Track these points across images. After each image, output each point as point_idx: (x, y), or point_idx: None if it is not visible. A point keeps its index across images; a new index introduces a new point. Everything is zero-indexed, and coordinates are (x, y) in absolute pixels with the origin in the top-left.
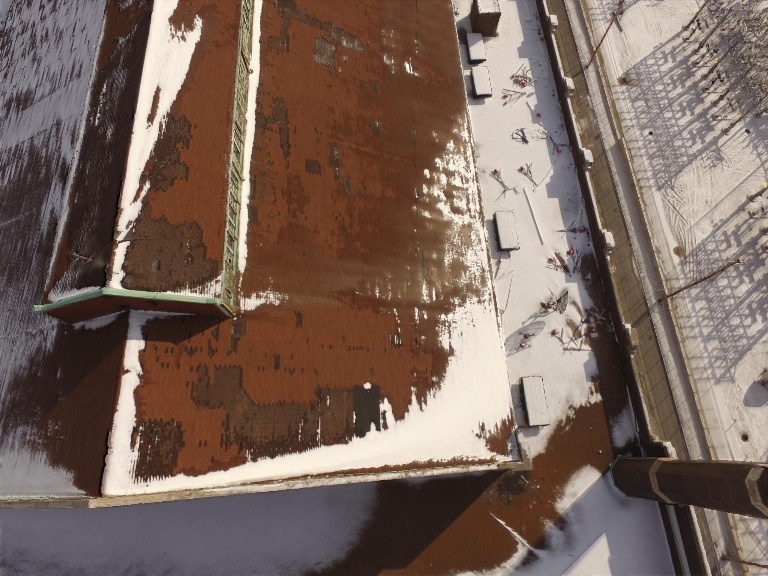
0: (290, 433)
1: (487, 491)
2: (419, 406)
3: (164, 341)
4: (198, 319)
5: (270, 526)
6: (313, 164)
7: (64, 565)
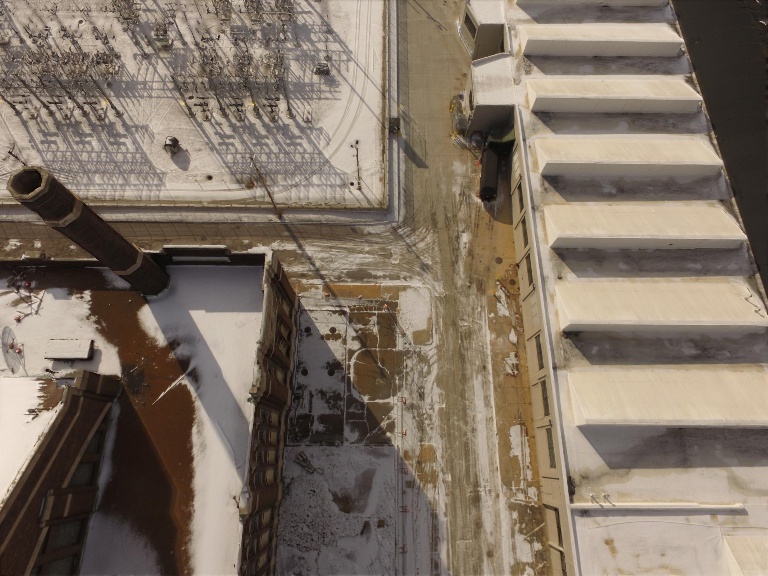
0: None
1: (134, 405)
2: None
3: None
4: None
5: None
6: None
7: None
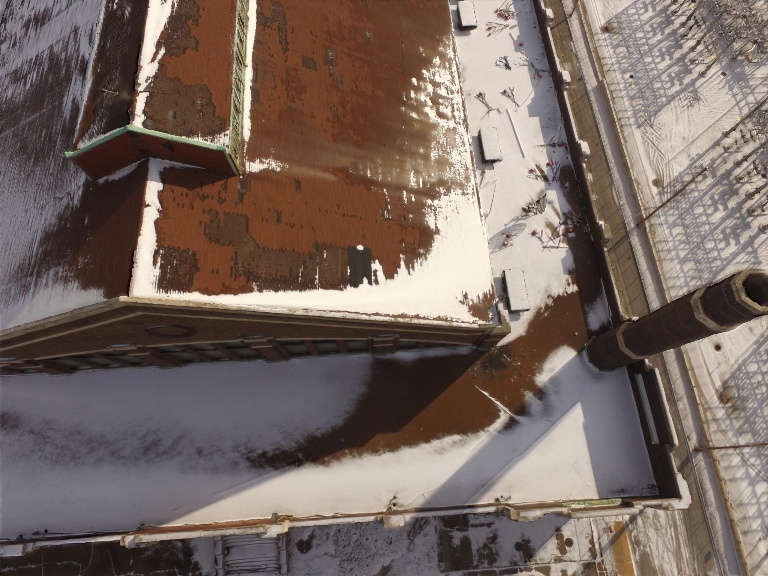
0: (291, 275)
1: (472, 367)
2: (407, 271)
3: (179, 186)
4: (209, 173)
5: (274, 398)
6: (309, 61)
7: (87, 432)
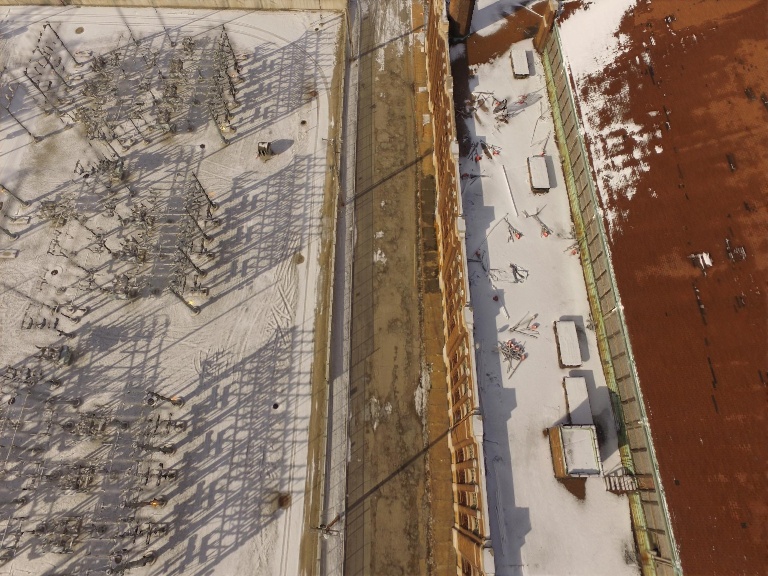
0: None
1: None
2: None
3: None
4: None
5: None
6: None
7: None
